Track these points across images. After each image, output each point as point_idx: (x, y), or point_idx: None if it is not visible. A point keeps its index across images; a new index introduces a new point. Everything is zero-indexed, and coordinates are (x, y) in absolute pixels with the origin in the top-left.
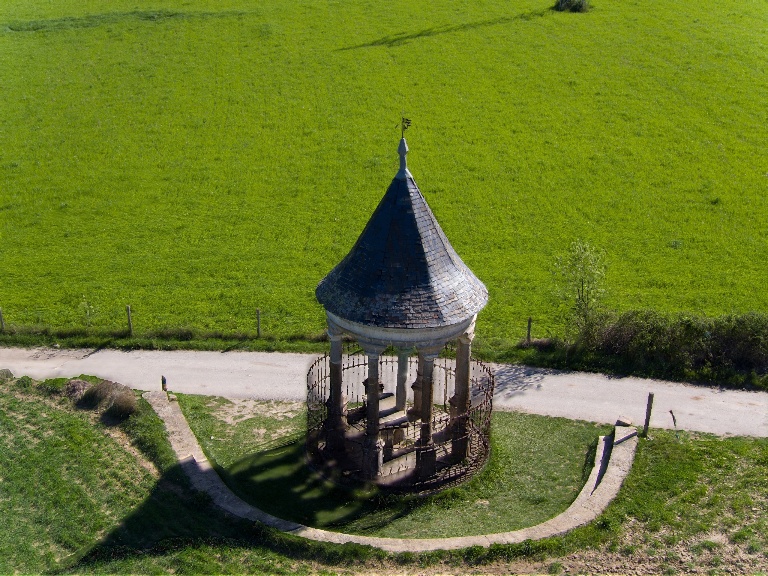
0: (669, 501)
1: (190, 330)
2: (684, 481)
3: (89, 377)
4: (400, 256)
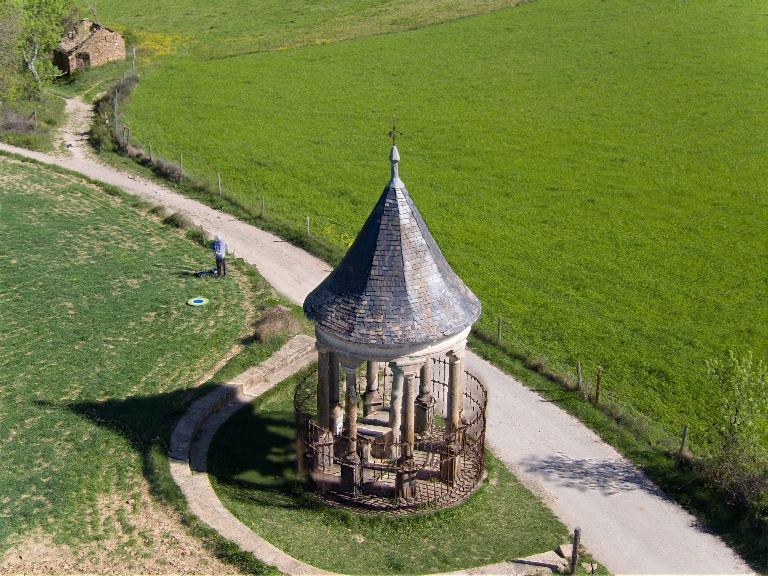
0: None
1: None
2: None
3: (297, 309)
4: (356, 261)
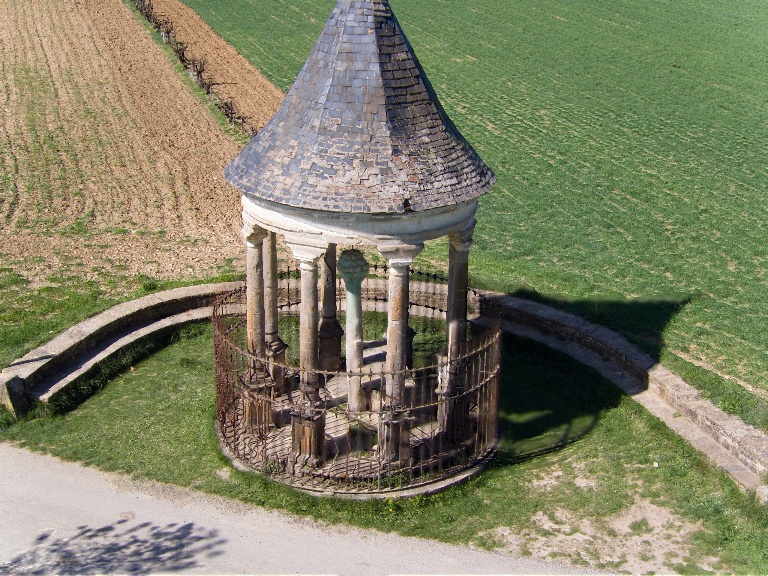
0: (50, 316)
1: None
2: (7, 329)
3: None
4: None
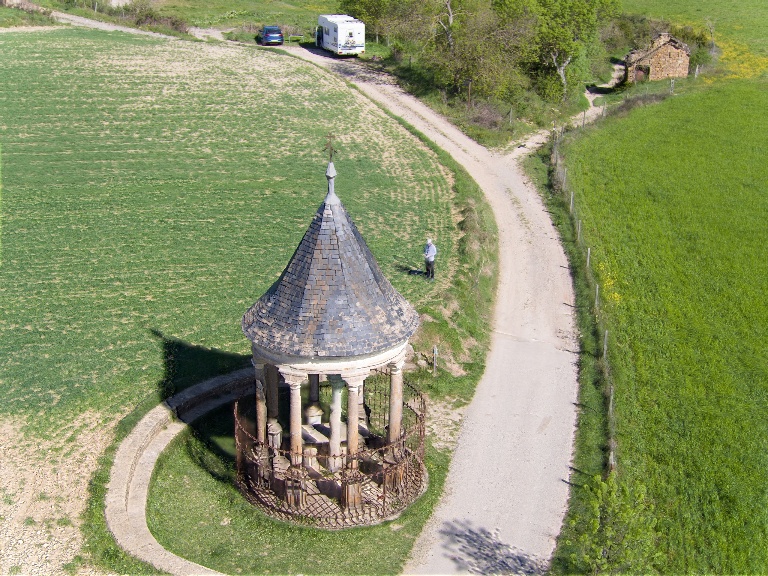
0: None
1: (606, 378)
2: None
3: None
4: None
